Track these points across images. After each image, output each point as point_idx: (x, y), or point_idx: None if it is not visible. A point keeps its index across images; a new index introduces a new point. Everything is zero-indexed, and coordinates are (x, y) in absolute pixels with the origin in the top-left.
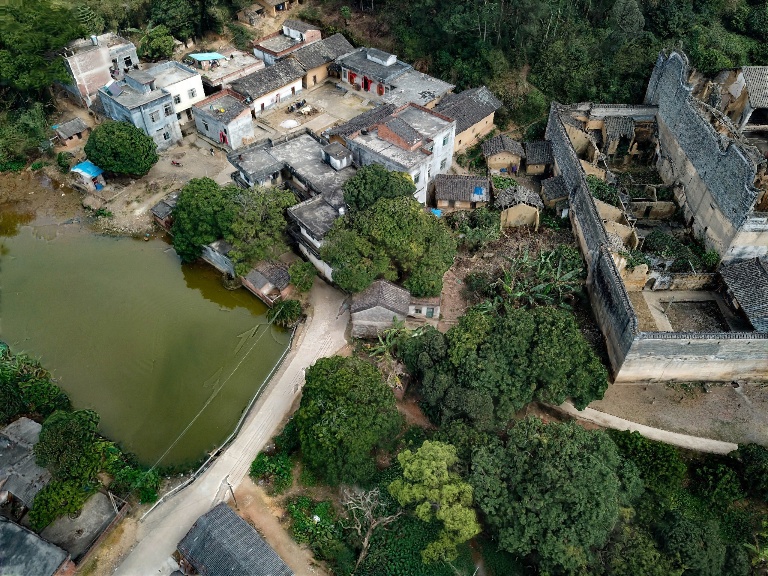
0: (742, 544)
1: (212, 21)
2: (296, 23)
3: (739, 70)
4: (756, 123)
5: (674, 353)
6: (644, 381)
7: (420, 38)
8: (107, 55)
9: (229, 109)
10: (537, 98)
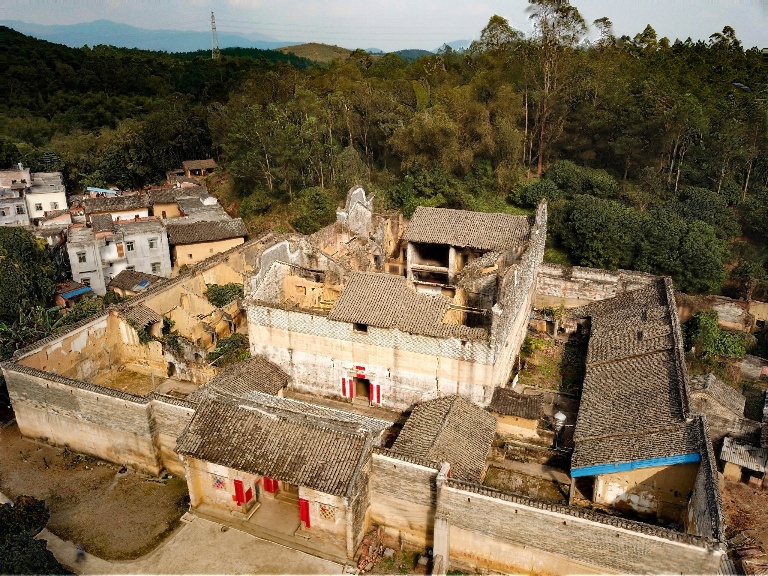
0: None
1: (141, 176)
2: (182, 178)
3: None
4: (436, 266)
5: (44, 399)
6: (44, 440)
7: (234, 186)
8: (27, 178)
9: (55, 213)
10: None
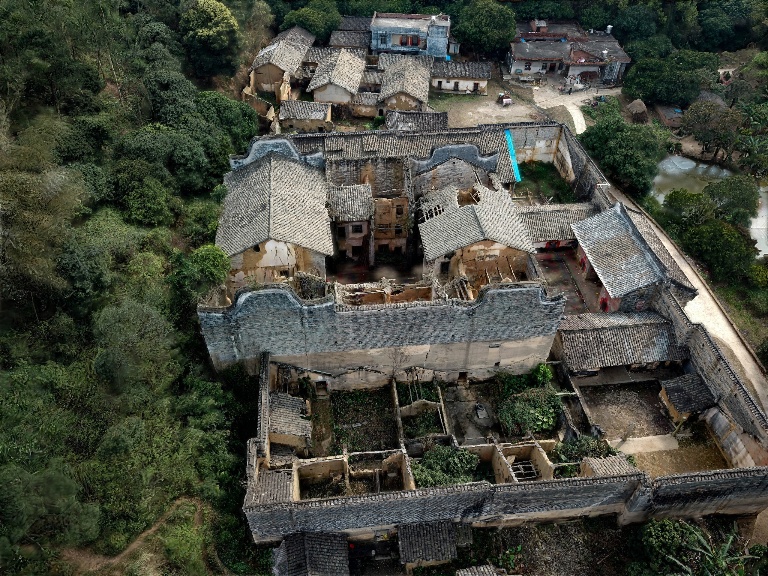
0: None
1: None
2: None
3: (264, 242)
4: None
5: None
6: None
7: None
8: None
9: None
10: (196, 539)
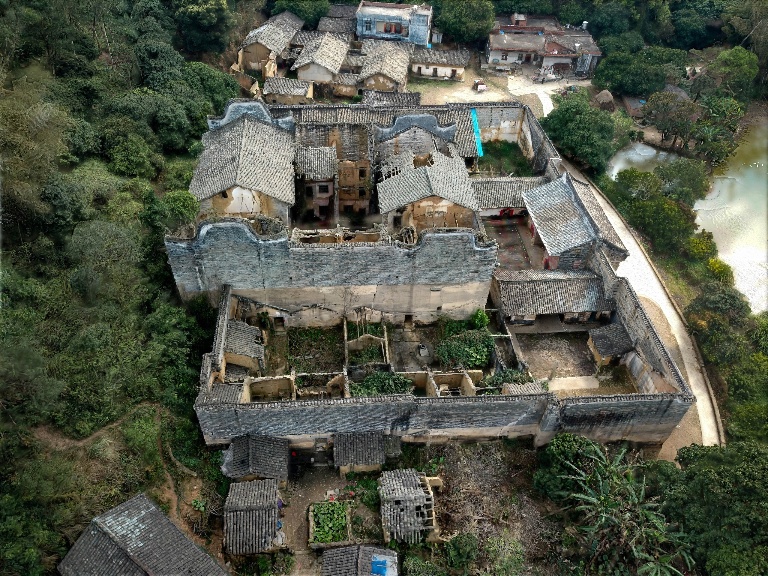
0: (761, 390)
1: None
2: None
3: (231, 189)
4: None
5: None
6: None
7: None
8: None
9: None
10: (151, 431)
